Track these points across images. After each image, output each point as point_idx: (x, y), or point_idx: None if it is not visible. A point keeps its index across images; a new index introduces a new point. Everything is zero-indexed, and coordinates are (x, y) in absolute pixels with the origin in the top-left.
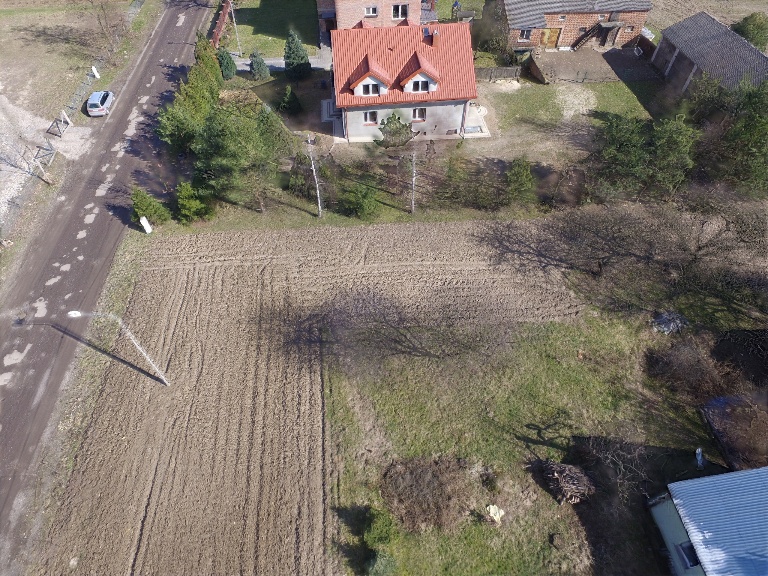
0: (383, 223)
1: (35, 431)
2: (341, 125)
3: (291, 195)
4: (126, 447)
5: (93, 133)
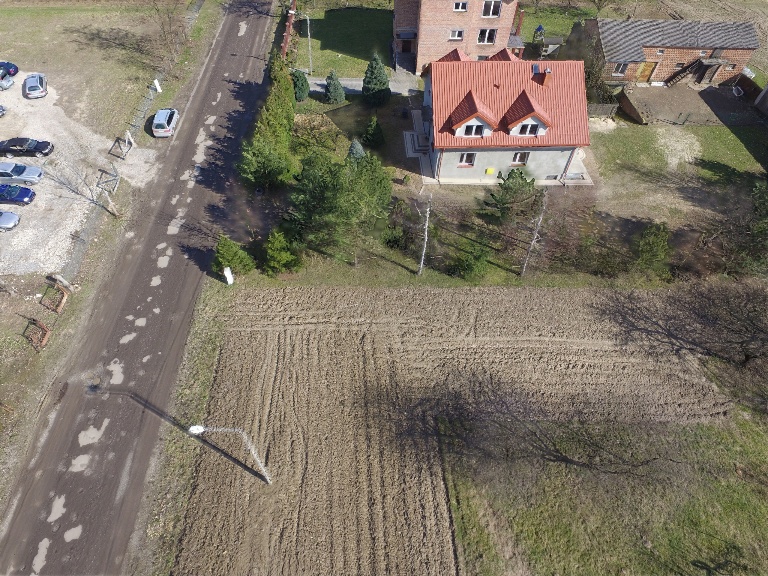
0: (490, 286)
1: (120, 536)
2: (429, 162)
3: (384, 245)
4: (229, 565)
5: (159, 157)
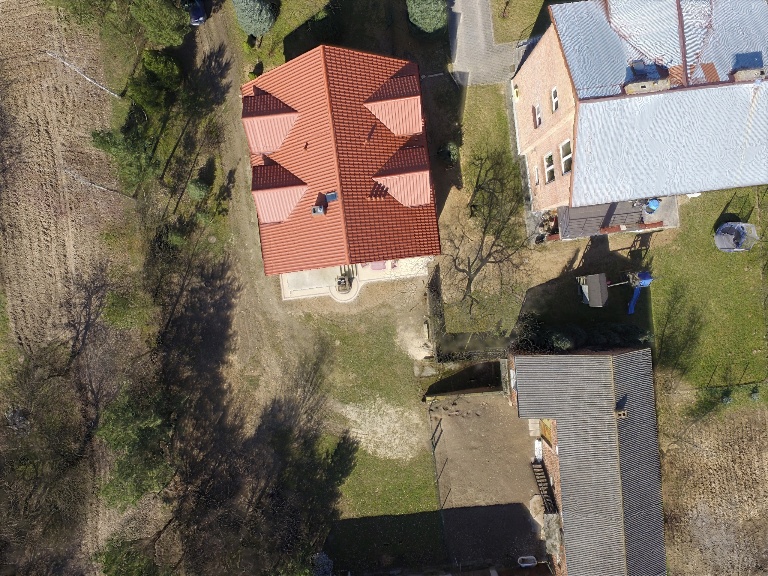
0: None
1: None
2: None
3: None
4: None
5: None
